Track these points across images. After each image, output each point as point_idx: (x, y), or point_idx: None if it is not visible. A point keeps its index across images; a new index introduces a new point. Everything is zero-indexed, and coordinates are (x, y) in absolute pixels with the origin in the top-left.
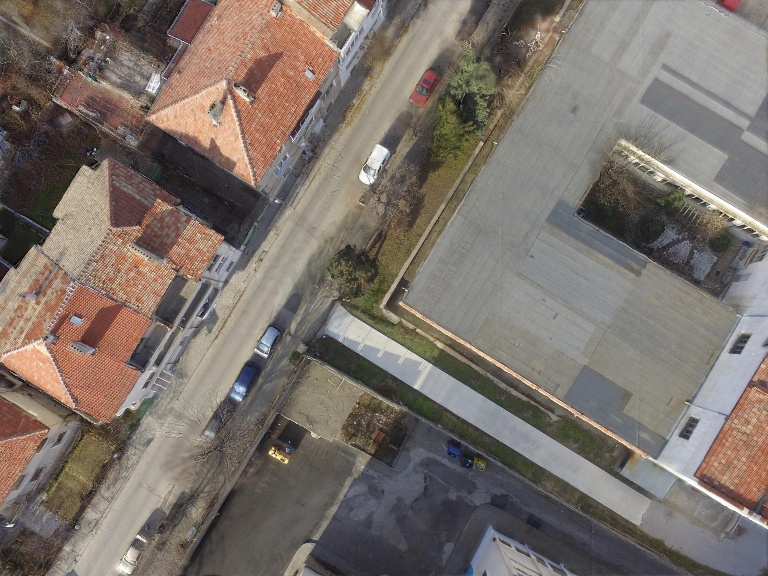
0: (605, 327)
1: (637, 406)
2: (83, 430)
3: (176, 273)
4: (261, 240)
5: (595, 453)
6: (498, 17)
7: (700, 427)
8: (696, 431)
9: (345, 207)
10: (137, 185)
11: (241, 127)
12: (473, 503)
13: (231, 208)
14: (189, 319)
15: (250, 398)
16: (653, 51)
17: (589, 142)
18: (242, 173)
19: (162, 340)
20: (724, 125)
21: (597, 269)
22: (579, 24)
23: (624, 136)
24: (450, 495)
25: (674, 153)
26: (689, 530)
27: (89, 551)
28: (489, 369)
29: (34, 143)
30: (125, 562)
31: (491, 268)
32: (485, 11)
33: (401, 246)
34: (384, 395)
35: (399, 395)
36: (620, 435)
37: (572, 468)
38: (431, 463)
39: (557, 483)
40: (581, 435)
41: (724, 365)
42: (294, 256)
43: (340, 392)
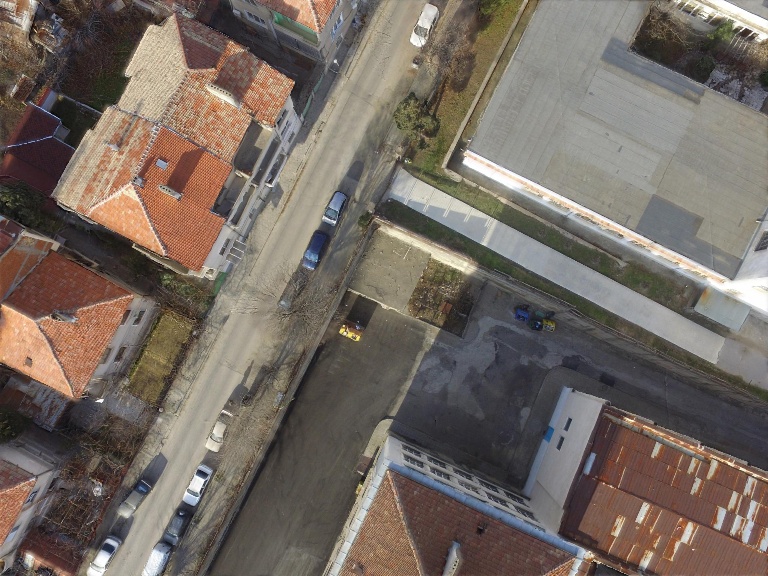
0: (670, 155)
1: (709, 229)
2: (162, 305)
3: (252, 118)
4: (319, 112)
5: (666, 295)
6: None
7: None
8: None
9: (398, 72)
10: (207, 35)
11: None
12: (545, 366)
13: None
14: (262, 176)
15: (321, 267)
16: None
17: None
18: (306, 21)
19: (242, 188)
20: None
21: (656, 100)
22: None
23: None
24: (522, 361)
25: None
26: (766, 364)
27: (175, 433)
28: (553, 222)
29: (91, 28)
30: (211, 441)
31: (552, 108)
32: None
33: (457, 106)
34: (454, 250)
35: (468, 252)
36: (695, 259)
37: (644, 312)
38: (500, 331)
39: (631, 328)
40: (650, 278)
41: None
42: (352, 125)
43: (406, 262)
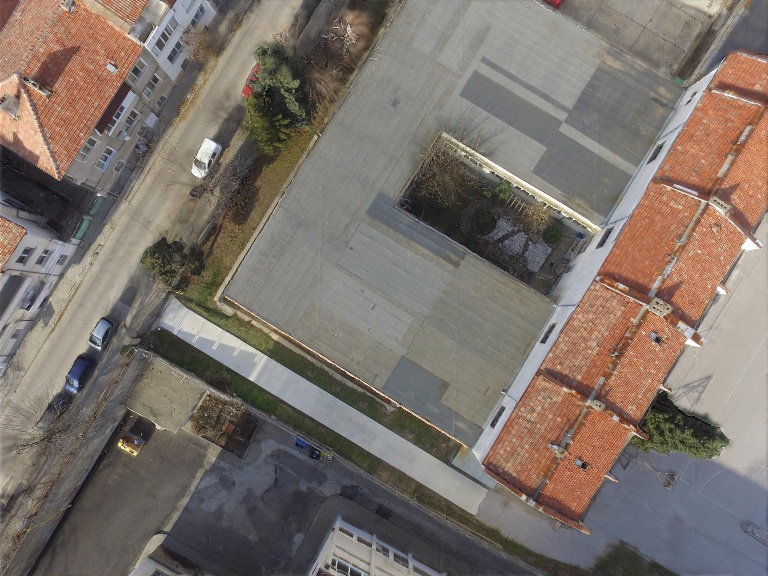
0: (422, 318)
1: (454, 396)
2: None
3: None
4: (97, 234)
5: (431, 444)
6: (329, 11)
7: (503, 416)
8: (500, 420)
9: (179, 201)
10: None
11: (39, 121)
12: (323, 494)
13: (66, 202)
14: (4, 311)
15: (86, 390)
16: (473, 44)
17: (409, 134)
18: (46, 166)
19: None
20: (542, 117)
21: (416, 260)
22: (401, 17)
23: (444, 128)
24: (300, 486)
25: (494, 145)
26: (525, 520)
27: None
28: (326, 361)
29: None
30: None
31: (311, 260)
32: (317, 5)
33: (235, 239)
34: (215, 386)
35: (233, 386)
36: (437, 425)
37: (409, 458)
38: (282, 455)
39: (393, 473)
40: (416, 426)
41: (534, 355)
42: (129, 249)
43: (184, 384)
